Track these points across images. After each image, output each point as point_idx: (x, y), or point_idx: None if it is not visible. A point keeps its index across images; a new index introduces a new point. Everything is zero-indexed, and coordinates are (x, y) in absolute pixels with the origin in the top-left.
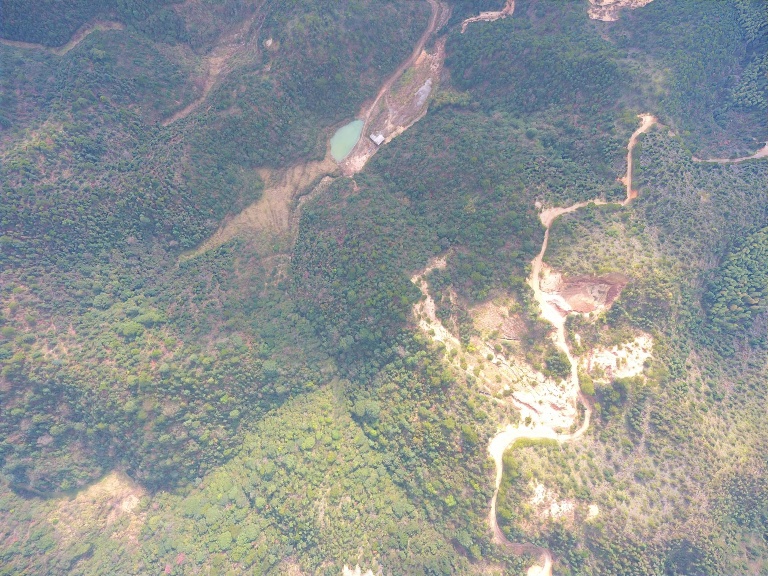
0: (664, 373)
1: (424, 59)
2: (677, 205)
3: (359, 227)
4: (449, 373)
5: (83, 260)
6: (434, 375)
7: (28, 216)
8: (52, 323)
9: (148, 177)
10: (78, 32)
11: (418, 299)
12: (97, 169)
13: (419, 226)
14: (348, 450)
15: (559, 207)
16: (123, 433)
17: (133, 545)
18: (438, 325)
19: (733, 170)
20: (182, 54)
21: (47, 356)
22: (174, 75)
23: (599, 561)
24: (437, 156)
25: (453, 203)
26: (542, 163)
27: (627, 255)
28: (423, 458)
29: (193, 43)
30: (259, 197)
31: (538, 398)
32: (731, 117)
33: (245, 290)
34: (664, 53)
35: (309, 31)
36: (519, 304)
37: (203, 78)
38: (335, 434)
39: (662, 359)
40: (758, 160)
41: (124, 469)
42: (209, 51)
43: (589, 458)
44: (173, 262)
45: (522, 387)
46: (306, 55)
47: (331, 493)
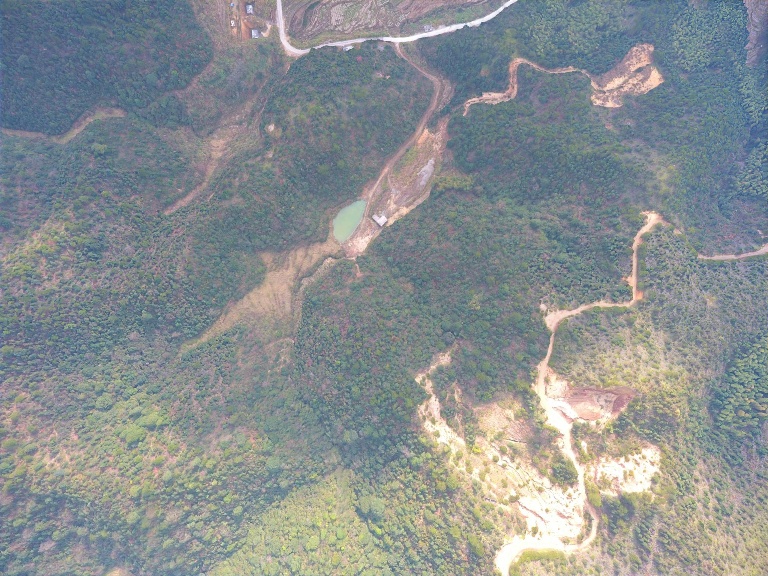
0: (672, 491)
1: (427, 138)
2: (683, 311)
3: (363, 319)
4: (455, 480)
5: (85, 360)
6: (439, 479)
7: (30, 324)
8: (54, 429)
9: (150, 273)
10: (79, 120)
11: (423, 400)
12: (99, 268)
13: (423, 317)
14: (353, 550)
15: (564, 310)
16: (126, 540)
17: None
18: (443, 425)
19: (739, 269)
20: (184, 138)
21: (49, 466)
22: (176, 163)
23: None
24: (441, 246)
25: (457, 296)
26: (547, 259)
27: (634, 367)
28: (429, 562)
29: (195, 127)
30: (261, 281)
31: (545, 506)
32: (736, 206)
33: (248, 381)
34: (669, 149)
35: (311, 121)
36: (525, 410)
37: (205, 162)
38: (340, 533)
39: (670, 475)
40: (764, 257)
41: (127, 569)
42: (211, 133)
43: (597, 573)
44: (175, 352)
45: (528, 492)
46: (308, 144)
47: None
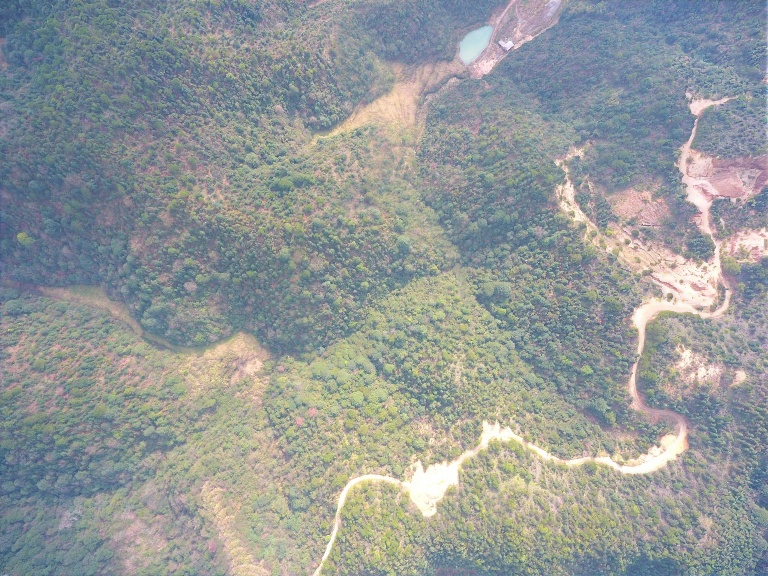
0: None
1: None
2: None
3: (497, 116)
4: (593, 248)
5: (236, 119)
6: (574, 253)
7: (198, 63)
8: (209, 171)
9: (301, 47)
10: None
11: (561, 180)
12: (256, 33)
13: (554, 121)
14: (478, 325)
15: (708, 99)
16: (269, 284)
17: (257, 405)
18: (577, 209)
19: None
20: None
21: (207, 199)
22: None
23: (741, 426)
24: (576, 55)
25: (592, 99)
26: (686, 63)
27: None
28: (556, 333)
29: None
30: (390, 89)
31: (679, 278)
32: None
33: (378, 171)
34: None
35: None
36: (666, 187)
37: None
38: (466, 309)
39: None
40: None
41: (256, 328)
42: None
43: (733, 332)
44: (310, 139)
45: (660, 269)
46: None
47: (468, 356)
